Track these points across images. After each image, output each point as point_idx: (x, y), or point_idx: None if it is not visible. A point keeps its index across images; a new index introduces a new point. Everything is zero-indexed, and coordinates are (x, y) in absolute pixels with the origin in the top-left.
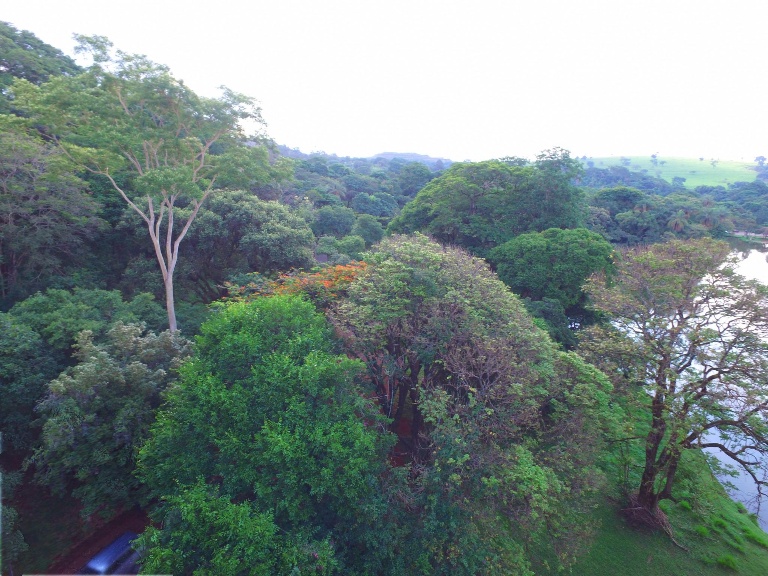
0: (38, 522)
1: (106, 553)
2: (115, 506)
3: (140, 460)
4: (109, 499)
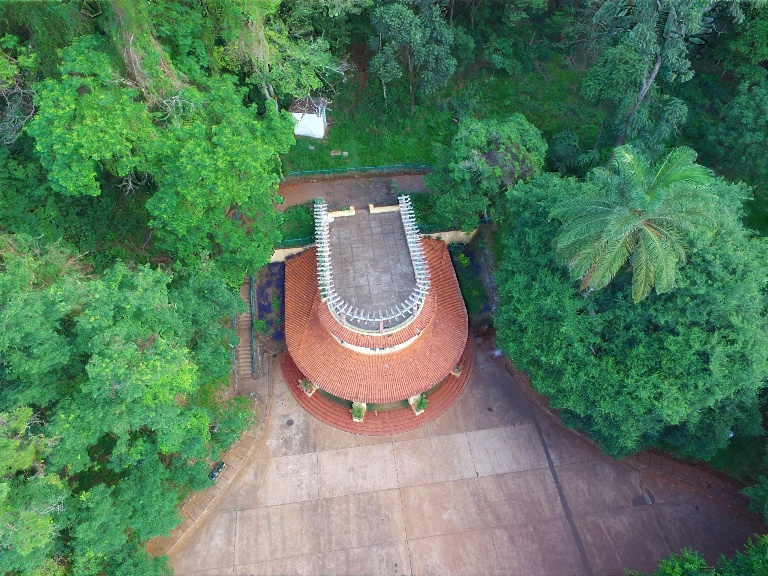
0: (753, 447)
1: (743, 505)
2: (761, 512)
3: (765, 539)
4: (763, 507)
